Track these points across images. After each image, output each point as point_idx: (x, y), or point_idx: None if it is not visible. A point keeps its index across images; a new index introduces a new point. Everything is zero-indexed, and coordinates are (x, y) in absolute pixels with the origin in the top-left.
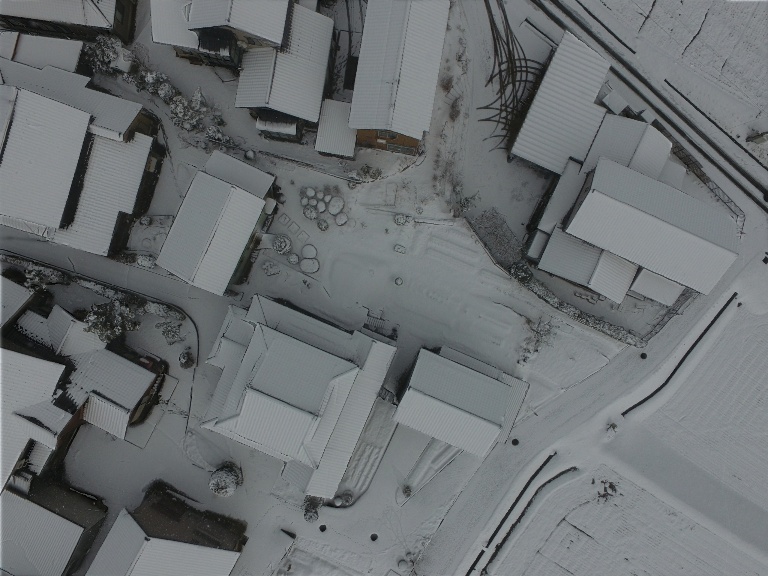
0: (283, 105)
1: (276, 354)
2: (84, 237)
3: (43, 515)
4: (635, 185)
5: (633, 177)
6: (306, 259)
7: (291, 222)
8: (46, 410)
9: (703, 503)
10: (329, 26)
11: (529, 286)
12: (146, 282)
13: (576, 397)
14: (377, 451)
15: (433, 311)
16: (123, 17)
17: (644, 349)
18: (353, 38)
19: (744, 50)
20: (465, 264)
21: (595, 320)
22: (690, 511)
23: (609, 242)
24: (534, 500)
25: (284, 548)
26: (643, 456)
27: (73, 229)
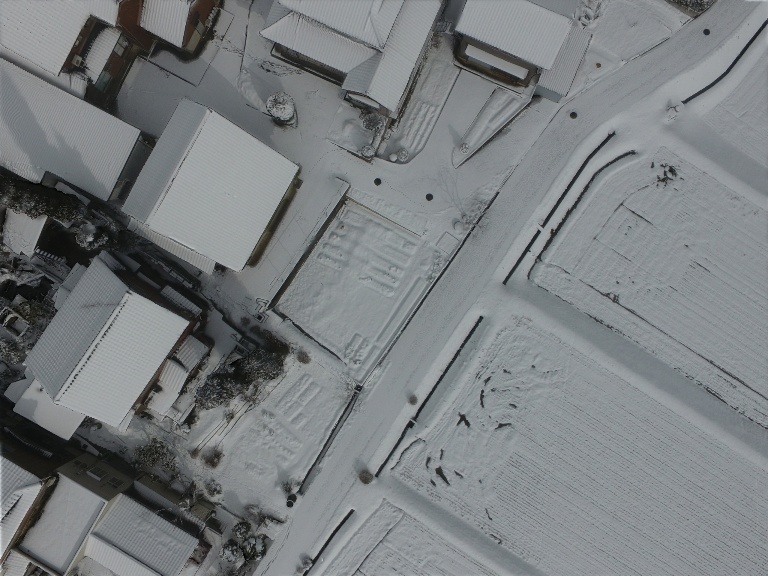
0: None
1: None
2: None
3: (100, 116)
4: None
5: None
6: None
7: None
8: None
9: (766, 190)
10: None
11: None
12: None
13: (636, 71)
14: (433, 110)
15: None
16: None
17: (707, 25)
18: None
19: None
20: None
21: None
22: (753, 194)
23: None
24: (591, 185)
25: (339, 192)
26: (704, 143)
27: None
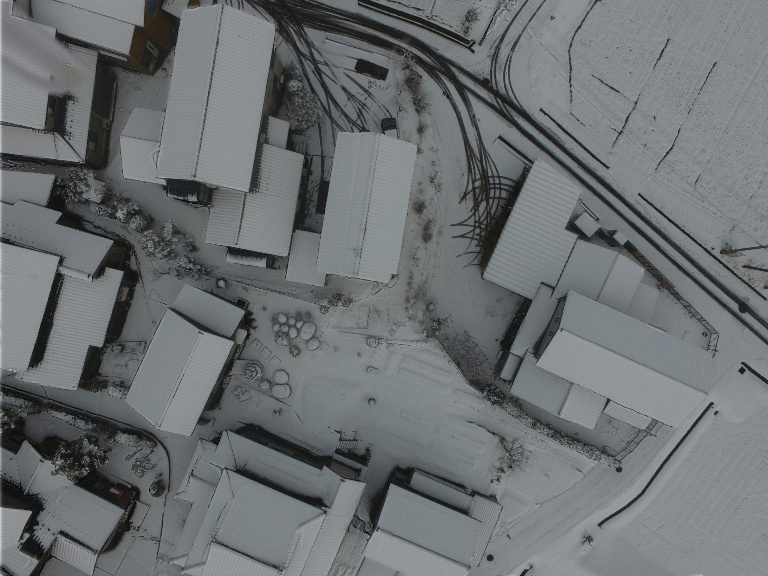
0: (252, 244)
1: (242, 502)
2: (54, 374)
3: None
4: (604, 321)
5: (602, 312)
6: (278, 385)
7: (263, 347)
8: (12, 557)
9: None
10: (299, 162)
11: (502, 406)
12: (118, 408)
13: (551, 512)
14: (350, 571)
15: (406, 431)
16: (96, 145)
17: None
18: (325, 163)
19: (717, 166)
20: (438, 384)
21: (568, 440)
22: None
23: (579, 377)
24: None
25: None
26: (620, 568)
27: (42, 367)
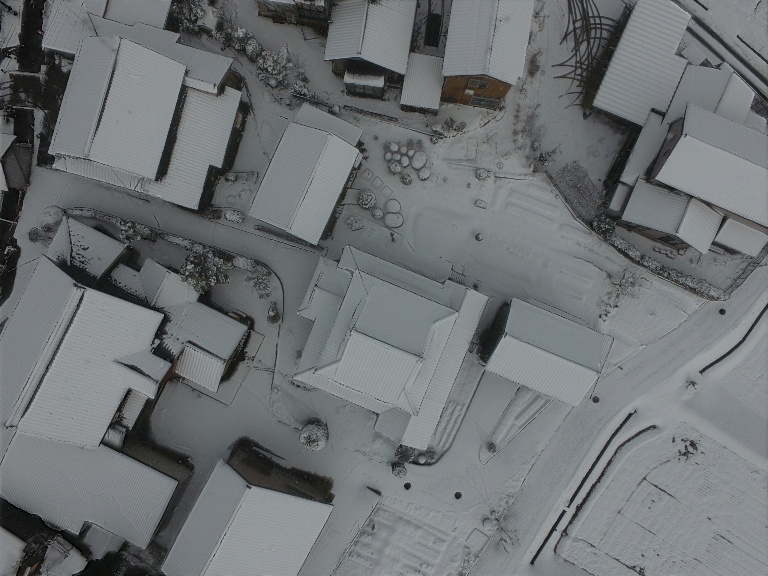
0: (374, 56)
1: (376, 299)
2: (176, 190)
3: (138, 468)
4: (725, 131)
5: (722, 123)
6: (390, 213)
7: (374, 177)
8: (146, 359)
9: None
10: None
11: (610, 240)
12: (231, 239)
13: (656, 354)
14: (460, 408)
15: (514, 266)
16: None
17: (723, 305)
18: None
19: None
20: (545, 219)
21: (677, 273)
22: None
23: (699, 188)
24: (614, 460)
25: (371, 505)
26: (722, 414)
27: (166, 182)
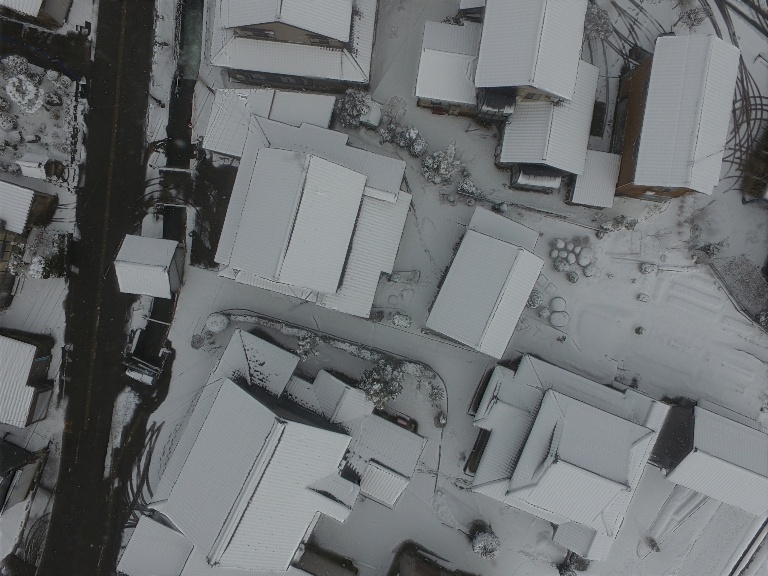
0: (557, 160)
1: (573, 421)
2: (351, 300)
3: None
4: None
5: None
6: (556, 312)
7: None
8: (336, 483)
9: None
10: (596, 75)
11: None
12: (392, 339)
13: None
14: None
15: (674, 360)
16: None
17: None
18: None
19: None
20: (708, 311)
21: None
22: None
23: None
24: (763, 546)
25: None
26: None
27: (341, 293)
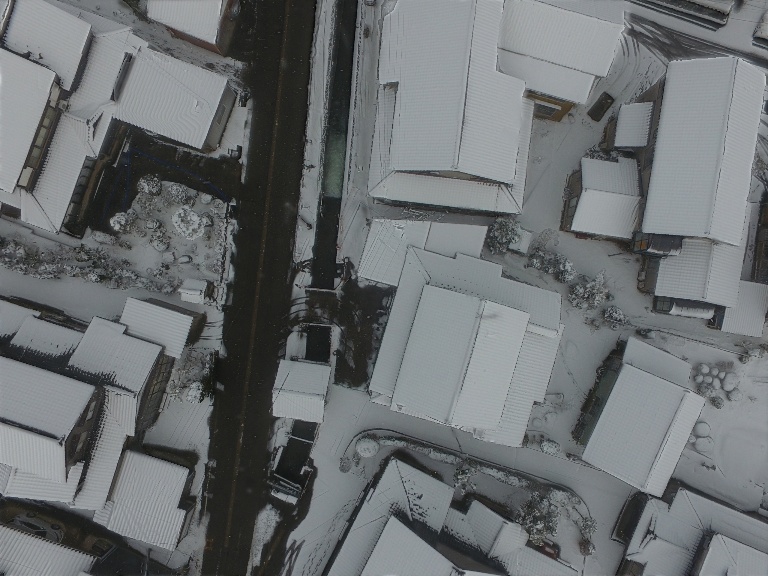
0: (715, 297)
1: (745, 569)
2: (506, 432)
3: None
4: None
5: None
6: (702, 438)
7: None
8: None
9: None
10: (749, 210)
11: None
12: (535, 462)
13: None
14: None
15: None
16: None
17: None
18: None
19: None
20: None
21: None
22: None
23: None
24: None
25: None
26: None
27: None
